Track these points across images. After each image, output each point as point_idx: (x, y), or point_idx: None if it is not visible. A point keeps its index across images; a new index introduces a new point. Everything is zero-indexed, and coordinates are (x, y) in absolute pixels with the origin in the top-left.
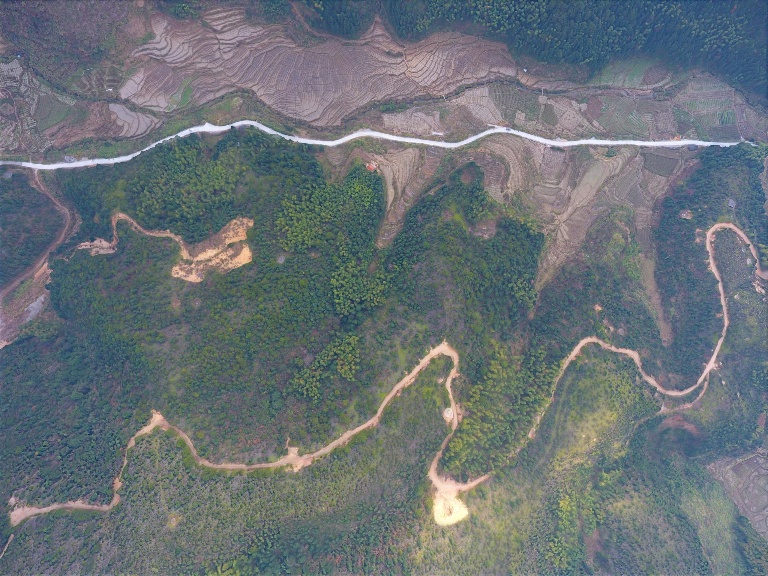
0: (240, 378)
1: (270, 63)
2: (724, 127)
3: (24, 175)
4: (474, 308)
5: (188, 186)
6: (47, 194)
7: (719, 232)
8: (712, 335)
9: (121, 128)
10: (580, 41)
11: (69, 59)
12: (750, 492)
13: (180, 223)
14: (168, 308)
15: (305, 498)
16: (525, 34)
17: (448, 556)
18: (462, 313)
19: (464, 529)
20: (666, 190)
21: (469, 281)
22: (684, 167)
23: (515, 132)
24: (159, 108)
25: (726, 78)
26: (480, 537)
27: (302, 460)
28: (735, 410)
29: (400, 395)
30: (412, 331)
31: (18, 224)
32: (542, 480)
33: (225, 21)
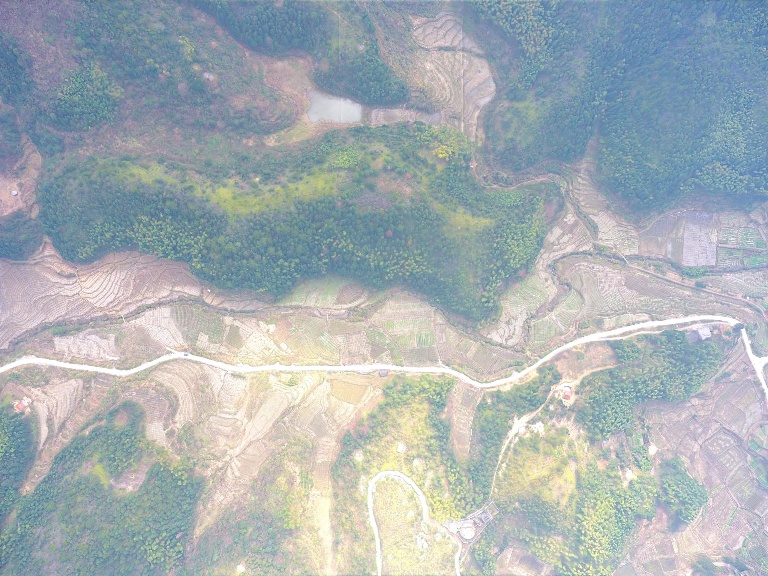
0: None
1: None
2: (421, 349)
3: None
4: None
5: None
6: None
7: (379, 484)
8: None
9: None
10: (247, 275)
11: None
12: None
13: None
14: None
15: None
16: None
17: None
18: None
19: None
20: (352, 419)
21: (79, 557)
22: (372, 395)
23: (193, 357)
24: None
25: (424, 298)
26: None
27: None
28: None
29: None
30: None
31: None
32: None
33: None
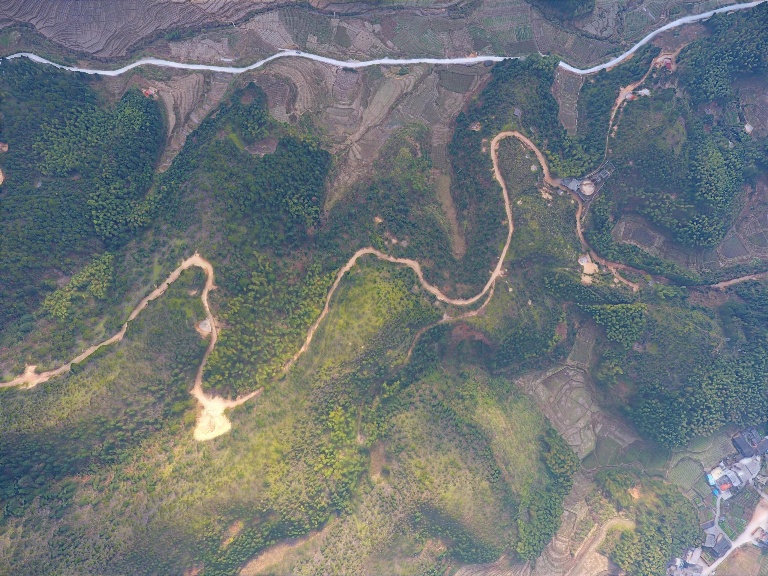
0: None
1: None
2: (521, 42)
3: None
4: (237, 222)
5: None
6: None
7: (501, 140)
8: (498, 243)
9: None
10: None
11: None
12: (563, 405)
13: None
14: None
15: (30, 412)
16: None
17: (198, 468)
18: (220, 226)
19: (221, 442)
20: (462, 106)
21: (231, 194)
22: (479, 83)
23: (306, 55)
24: None
25: None
26: (237, 449)
27: (40, 378)
28: (524, 317)
29: (145, 308)
30: (170, 247)
31: None
32: (307, 390)
33: None
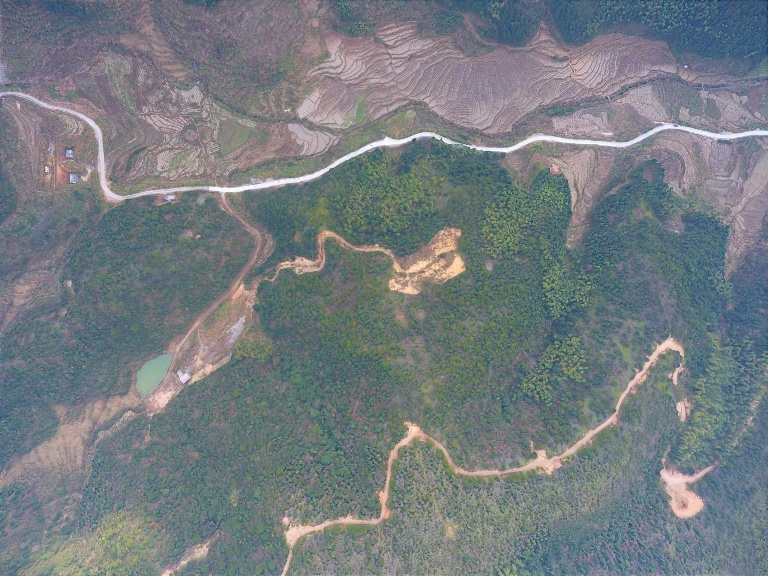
0: (480, 385)
1: (440, 75)
2: None
3: (214, 199)
4: (686, 303)
5: (387, 200)
6: (236, 217)
7: None
8: None
9: (301, 147)
10: (748, 35)
11: (249, 82)
12: None
13: (388, 237)
14: (396, 321)
15: (569, 499)
16: (692, 31)
17: (699, 548)
18: (679, 308)
19: (706, 520)
20: None
21: (679, 276)
22: None
23: (682, 128)
24: (336, 125)
25: None
26: (723, 527)
27: (550, 462)
28: None
29: (637, 392)
30: (630, 329)
31: (220, 248)
32: None
33: (397, 36)
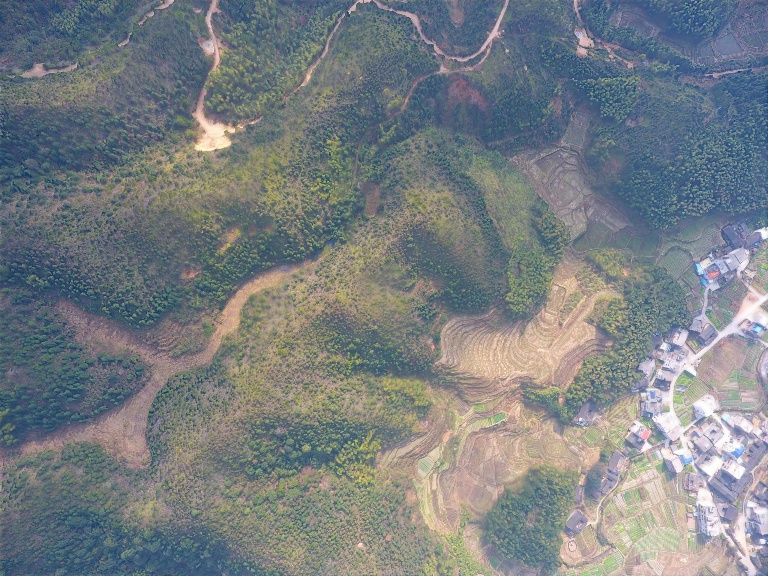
0: None
1: None
2: None
3: None
4: None
5: None
6: None
7: None
8: (496, 7)
9: None
10: None
11: None
12: (556, 187)
13: None
14: None
15: (38, 90)
16: None
17: (198, 167)
18: None
19: (221, 151)
20: None
21: None
22: None
23: None
24: None
25: None
26: (236, 157)
27: None
28: (520, 78)
29: None
30: None
31: None
32: (306, 113)
33: None
